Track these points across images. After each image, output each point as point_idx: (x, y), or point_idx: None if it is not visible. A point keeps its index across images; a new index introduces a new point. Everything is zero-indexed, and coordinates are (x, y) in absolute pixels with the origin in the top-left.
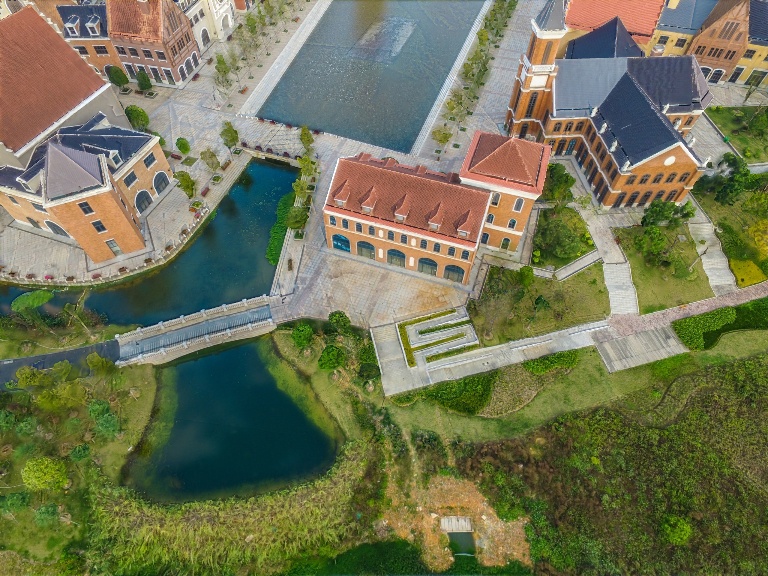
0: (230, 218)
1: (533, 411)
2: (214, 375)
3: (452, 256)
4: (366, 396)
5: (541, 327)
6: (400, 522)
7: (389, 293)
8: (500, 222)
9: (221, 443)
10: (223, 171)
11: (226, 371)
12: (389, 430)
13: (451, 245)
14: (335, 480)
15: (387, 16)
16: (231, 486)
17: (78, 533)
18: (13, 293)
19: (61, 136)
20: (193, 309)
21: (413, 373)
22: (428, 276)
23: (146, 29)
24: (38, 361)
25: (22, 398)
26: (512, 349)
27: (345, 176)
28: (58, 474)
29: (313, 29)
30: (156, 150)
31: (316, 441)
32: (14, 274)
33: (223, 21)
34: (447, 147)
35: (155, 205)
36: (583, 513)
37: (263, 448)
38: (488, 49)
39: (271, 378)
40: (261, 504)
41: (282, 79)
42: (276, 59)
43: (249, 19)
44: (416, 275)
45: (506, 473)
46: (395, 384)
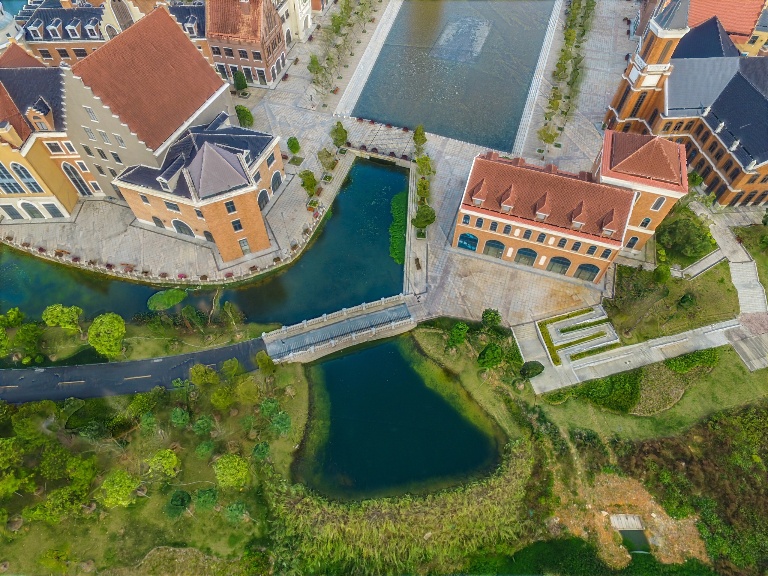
0: (346, 217)
1: (684, 409)
2: (362, 373)
3: (591, 255)
4: (517, 394)
5: (675, 326)
6: (572, 520)
7: (522, 292)
8: (632, 221)
9: (383, 441)
10: (332, 171)
11: (373, 369)
12: (546, 428)
13: (594, 244)
14: (508, 478)
15: (461, 16)
16: (400, 484)
17: (257, 530)
18: (146, 292)
19: (195, 135)
20: (328, 308)
21: (559, 371)
22: (557, 275)
23: (245, 29)
24: (187, 359)
25: (180, 396)
26: (651, 348)
27: (482, 175)
28: (246, 471)
29: (390, 29)
30: (276, 150)
31: (476, 439)
32: (147, 273)
33: (304, 21)
34: (549, 147)
35: (272, 204)
36: (755, 511)
37: (426, 446)
38: (571, 49)
39: (418, 376)
40: (439, 501)
41: (369, 79)
42: (361, 59)
43: (335, 19)
44: (545, 274)
45: (671, 471)
46: (543, 382)
